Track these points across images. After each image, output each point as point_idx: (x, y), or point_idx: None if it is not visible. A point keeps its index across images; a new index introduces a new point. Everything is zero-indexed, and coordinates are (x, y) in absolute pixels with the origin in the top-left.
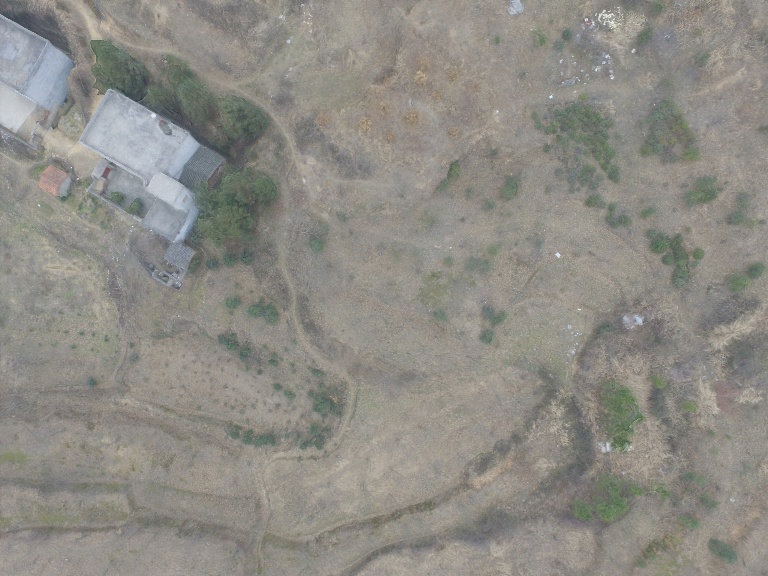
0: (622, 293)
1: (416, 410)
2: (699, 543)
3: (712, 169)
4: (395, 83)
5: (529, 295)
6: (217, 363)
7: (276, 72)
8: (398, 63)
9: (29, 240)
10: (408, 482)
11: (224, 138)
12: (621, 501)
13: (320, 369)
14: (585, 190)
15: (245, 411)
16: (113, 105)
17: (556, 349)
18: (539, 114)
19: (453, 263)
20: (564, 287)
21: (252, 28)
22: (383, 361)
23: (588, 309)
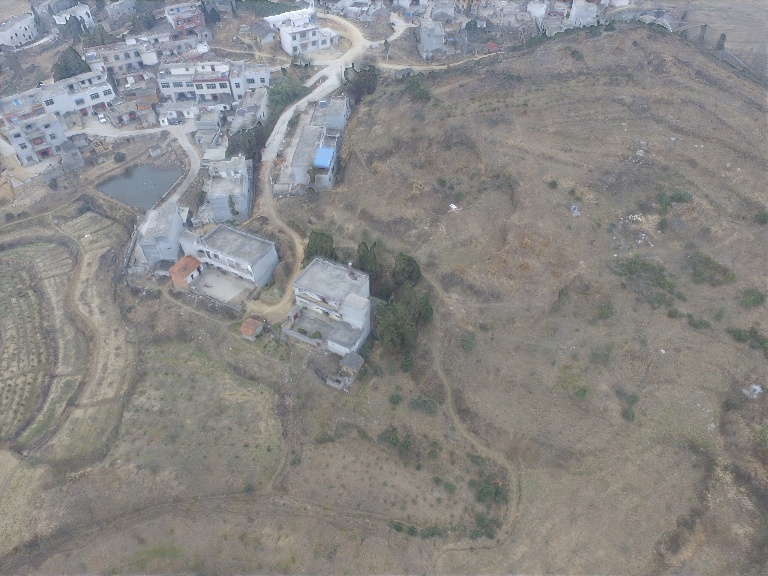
0: (730, 375)
1: (582, 491)
2: None
3: (751, 285)
4: (509, 249)
5: (652, 381)
6: (376, 462)
7: (425, 252)
8: (509, 239)
9: (214, 376)
10: (598, 569)
11: (392, 284)
12: None
13: (479, 455)
14: (664, 307)
15: (406, 507)
16: (317, 267)
17: (696, 424)
18: (611, 265)
19: (579, 359)
20: (679, 373)
21: (408, 232)
22: (539, 442)
23: (708, 390)
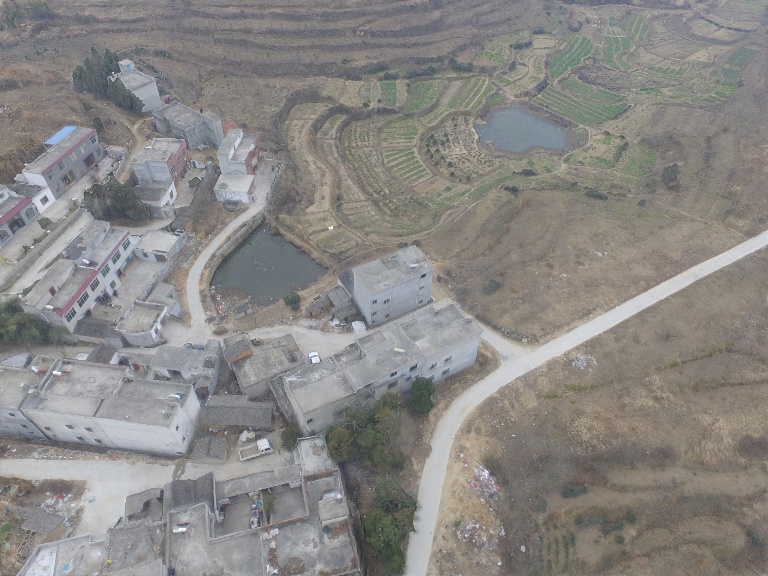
0: None
1: None
2: (17, 1)
3: None
4: None
5: None
6: None
7: None
8: (2, 77)
9: None
10: None
11: None
12: (32, 7)
13: None
14: None
15: None
16: None
17: None
18: None
19: None
20: (5, 54)
21: None
22: None
23: None
